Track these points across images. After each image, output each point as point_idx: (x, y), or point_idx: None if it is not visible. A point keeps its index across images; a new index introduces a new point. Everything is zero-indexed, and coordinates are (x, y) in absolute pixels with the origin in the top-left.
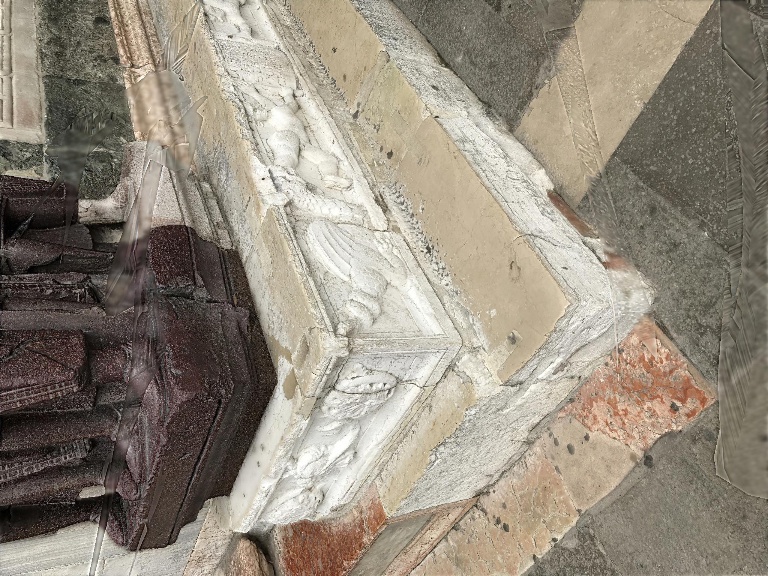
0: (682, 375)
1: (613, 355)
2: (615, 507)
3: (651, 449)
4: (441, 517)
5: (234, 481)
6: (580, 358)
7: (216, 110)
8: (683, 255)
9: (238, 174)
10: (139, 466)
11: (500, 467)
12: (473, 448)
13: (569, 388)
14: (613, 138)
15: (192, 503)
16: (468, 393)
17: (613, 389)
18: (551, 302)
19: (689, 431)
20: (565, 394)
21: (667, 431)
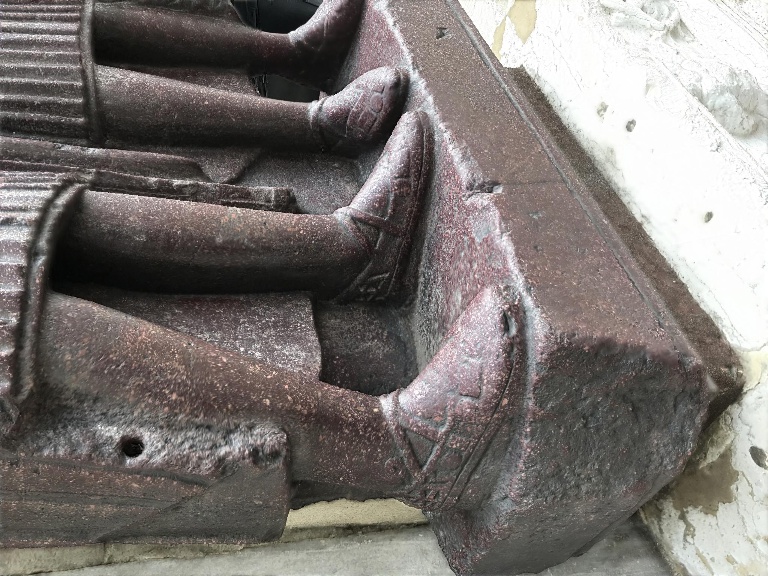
0: None
1: None
2: None
3: None
4: None
5: (689, 296)
6: None
7: None
8: None
9: None
10: None
11: None
12: None
13: None
14: None
15: None
16: None
17: None
18: None
19: None
20: None
21: None
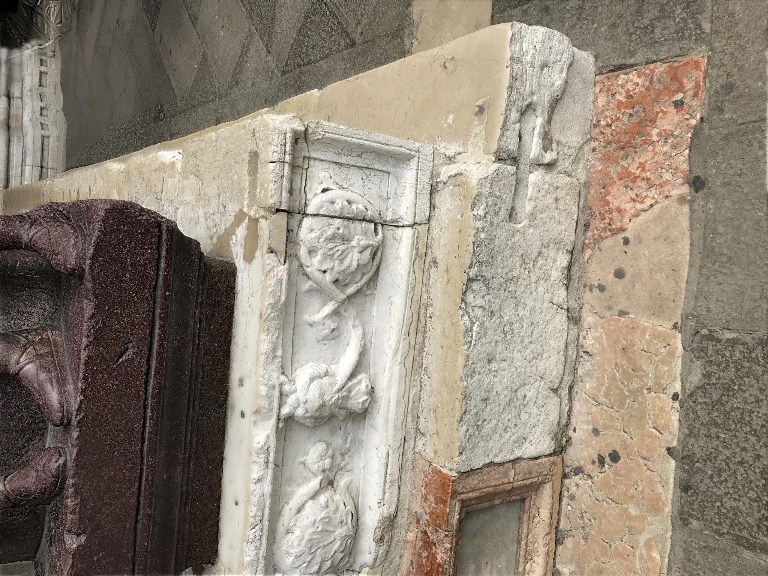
0: (662, 70)
1: (594, 135)
2: (705, 271)
3: (690, 170)
4: (532, 524)
5: (218, 514)
6: (562, 137)
7: (117, 194)
8: (592, 4)
9: (148, 187)
10: (58, 390)
11: (560, 371)
12: (510, 306)
13: (573, 195)
14: (485, 9)
15: (158, 542)
16: (464, 186)
17: (615, 161)
18: (494, 37)
19: (708, 110)
20: (574, 207)
21: (690, 135)
